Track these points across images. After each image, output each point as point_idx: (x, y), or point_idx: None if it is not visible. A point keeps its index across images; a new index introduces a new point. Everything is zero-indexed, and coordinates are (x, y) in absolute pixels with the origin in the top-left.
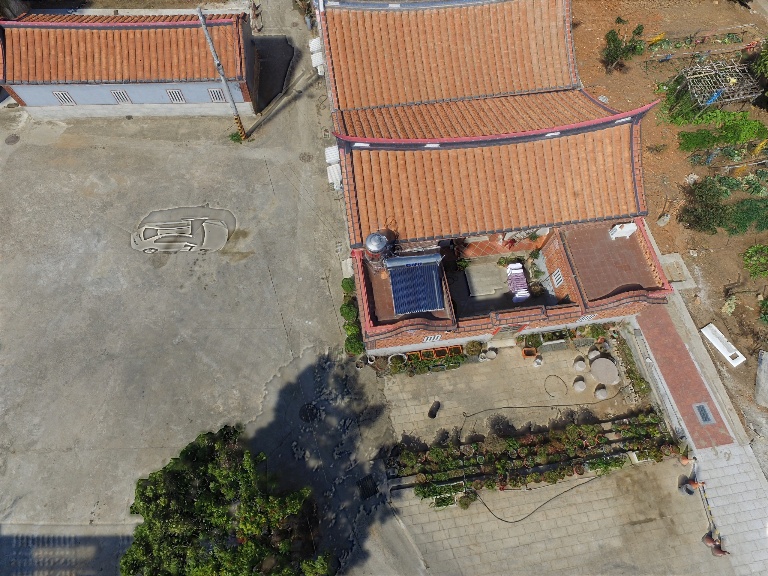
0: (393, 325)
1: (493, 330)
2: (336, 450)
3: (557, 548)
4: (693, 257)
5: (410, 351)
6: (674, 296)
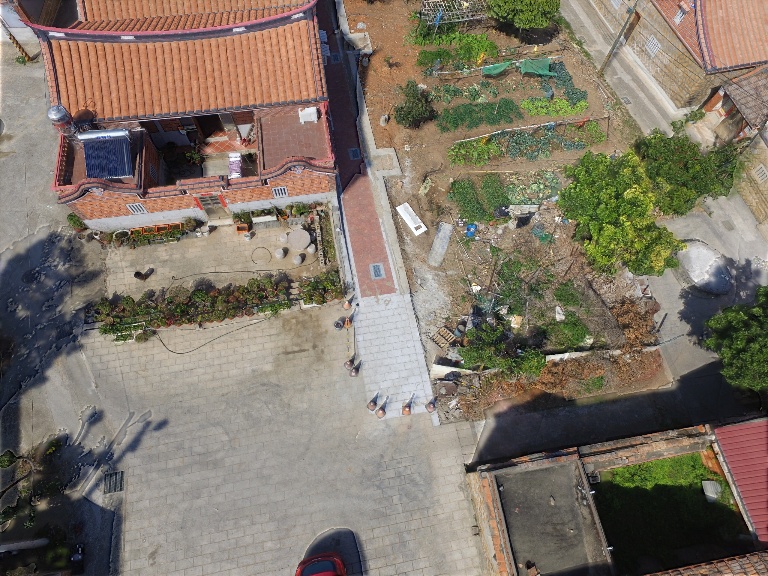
0: (75, 185)
1: (193, 202)
2: (46, 304)
3: (215, 372)
4: (407, 151)
5: (134, 227)
6: (377, 181)
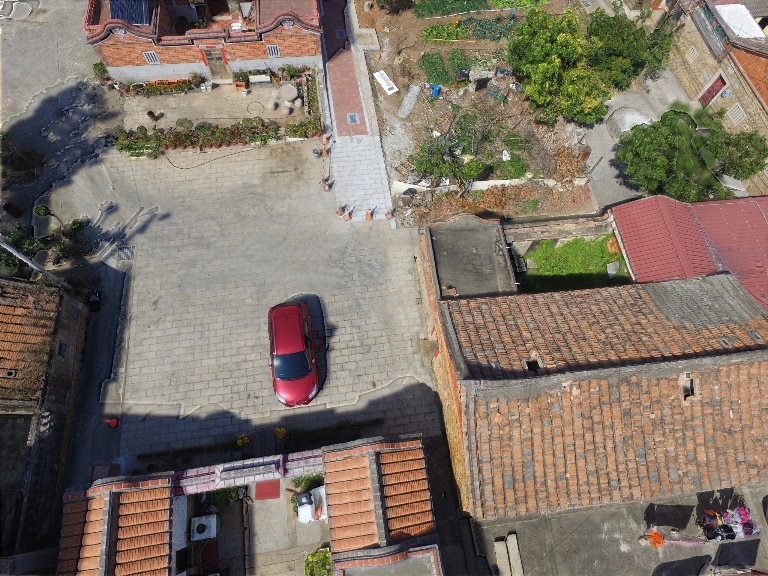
0: (101, 25)
1: (199, 55)
2: (73, 132)
3: (212, 183)
4: (386, 33)
5: (148, 81)
6: (358, 52)
